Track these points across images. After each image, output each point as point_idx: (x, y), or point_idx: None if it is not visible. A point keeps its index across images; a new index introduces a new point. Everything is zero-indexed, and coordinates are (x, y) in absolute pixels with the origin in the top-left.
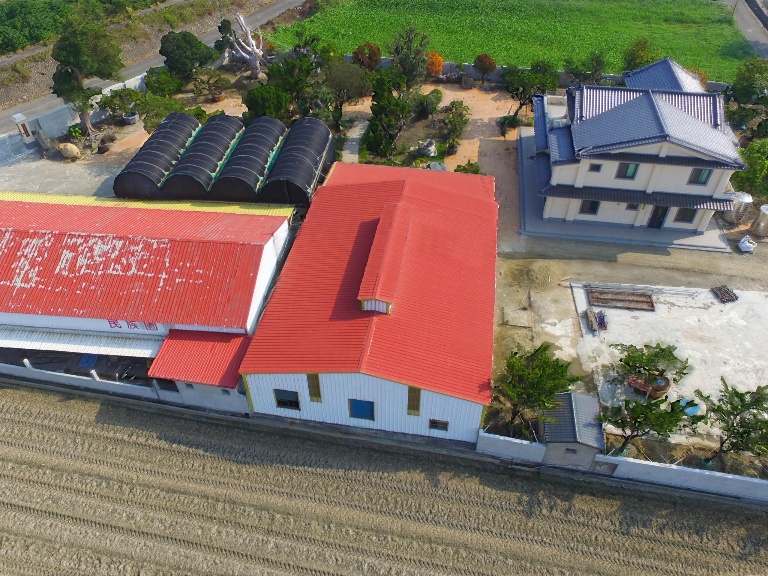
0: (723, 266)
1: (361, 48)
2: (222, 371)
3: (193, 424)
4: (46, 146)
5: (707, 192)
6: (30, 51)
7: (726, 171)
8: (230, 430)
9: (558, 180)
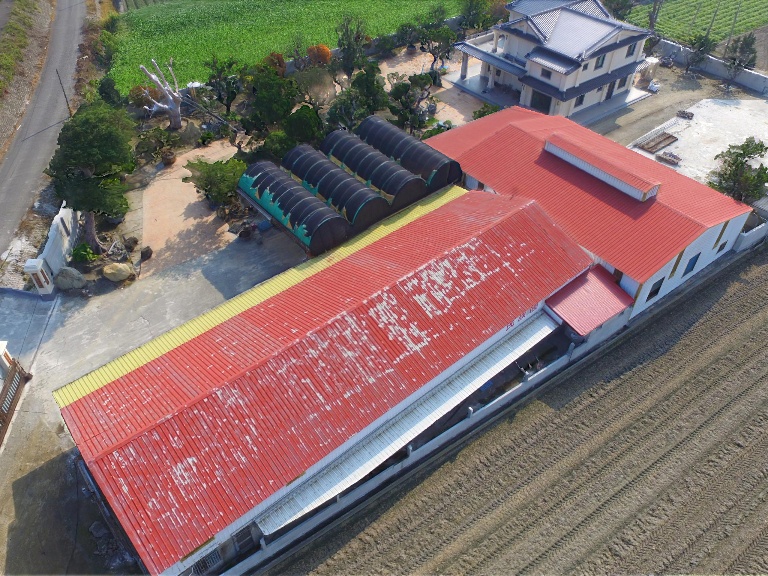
0: (661, 103)
1: (268, 60)
2: (615, 298)
3: (607, 358)
4: (83, 282)
5: (633, 60)
6: None
7: (644, 40)
8: (629, 343)
9: (566, 86)
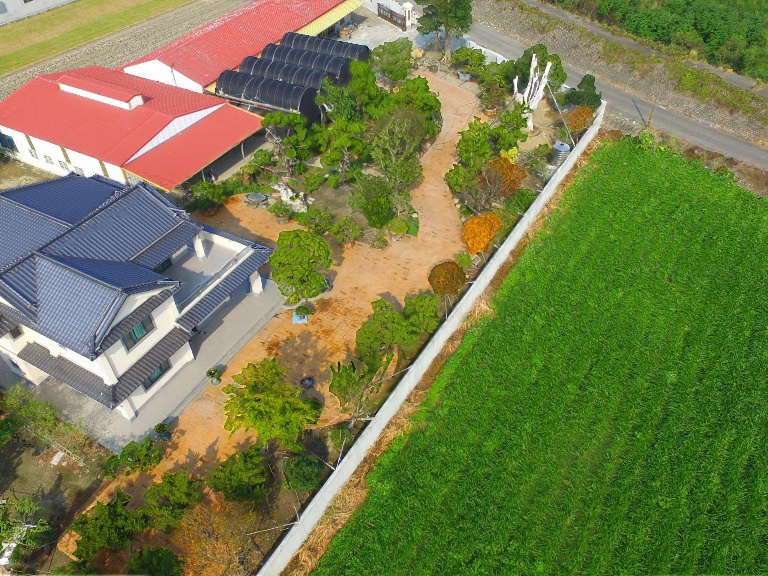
0: None
1: None
2: None
3: None
4: None
5: None
6: (590, 24)
7: None
8: None
9: None
